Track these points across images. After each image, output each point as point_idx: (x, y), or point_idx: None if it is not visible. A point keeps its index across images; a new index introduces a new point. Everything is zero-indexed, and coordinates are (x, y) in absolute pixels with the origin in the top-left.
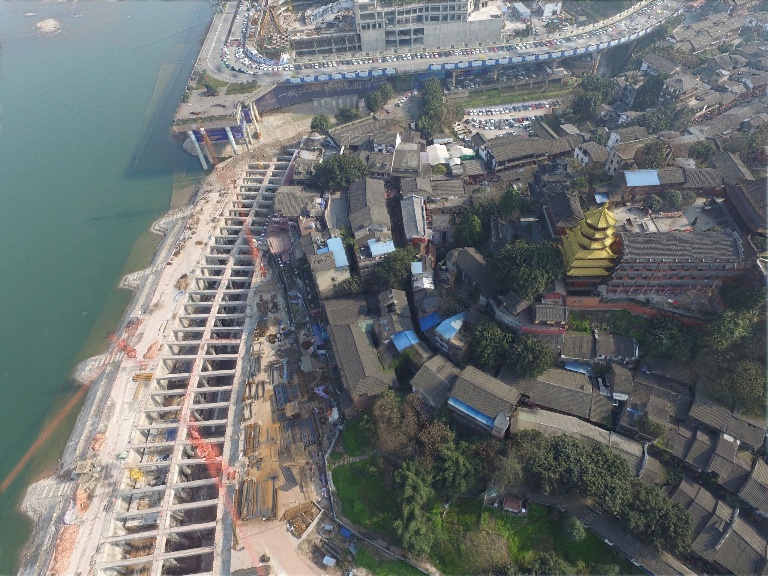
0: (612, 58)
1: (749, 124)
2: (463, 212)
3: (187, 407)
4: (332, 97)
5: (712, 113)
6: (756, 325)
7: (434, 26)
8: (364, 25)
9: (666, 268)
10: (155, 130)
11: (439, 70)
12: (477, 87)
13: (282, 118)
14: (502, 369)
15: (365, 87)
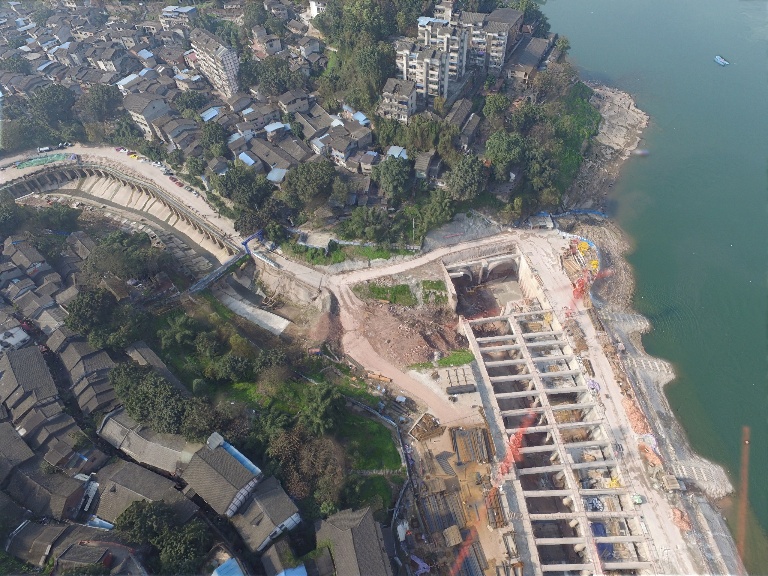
0: None
1: None
2: None
3: (596, 564)
4: None
5: None
6: None
7: None
8: None
9: None
10: None
11: None
12: None
13: None
14: (186, 520)
15: None
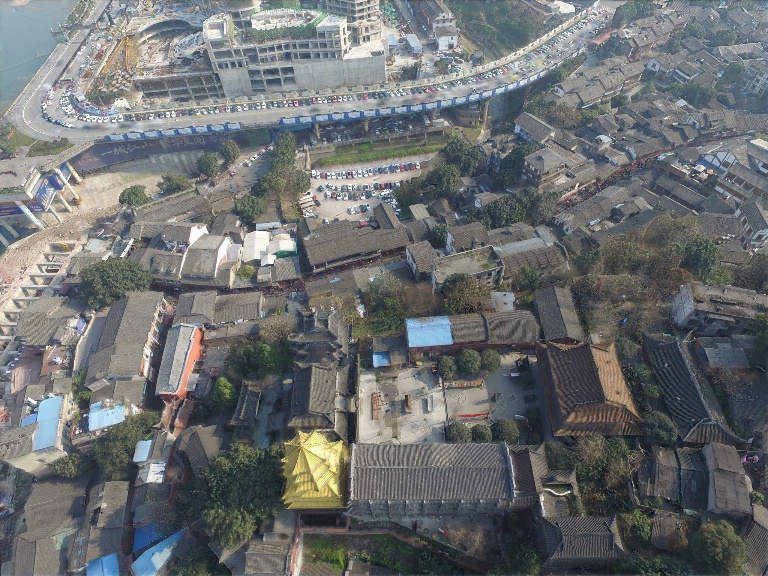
0: (509, 101)
1: (620, 212)
2: (253, 340)
3: None
4: (172, 153)
5: (588, 190)
6: None
7: (305, 65)
8: (221, 64)
9: (416, 506)
10: None
11: (294, 124)
12: (344, 141)
13: (110, 179)
14: None
15: (210, 142)
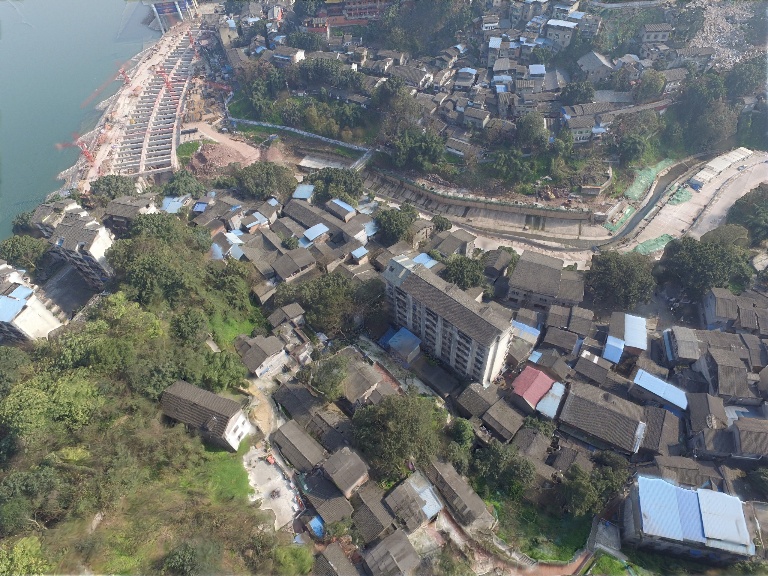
0: None
1: None
2: None
3: (158, 102)
4: None
5: None
6: (405, 17)
7: None
8: None
9: None
10: (129, 21)
11: None
12: None
13: (213, 6)
14: None
15: None
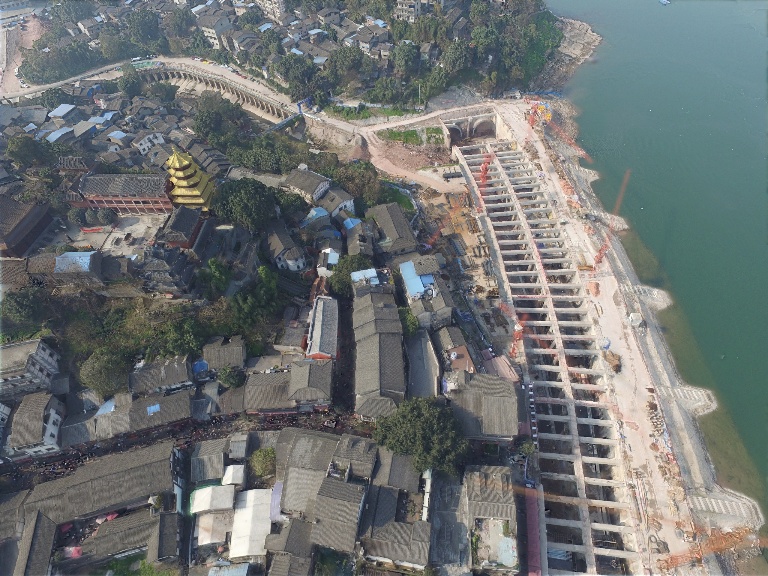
0: None
1: None
2: None
3: (534, 249)
4: None
5: None
6: None
7: None
8: None
9: None
10: None
11: None
12: None
13: None
14: None
15: None
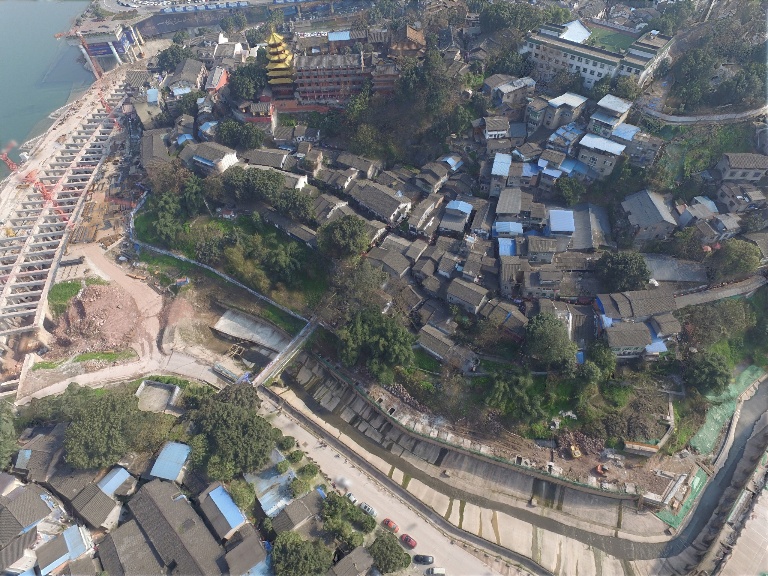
0: None
1: None
2: None
3: (51, 199)
4: (202, 26)
5: None
6: (378, 108)
7: None
8: None
9: (323, 74)
10: (64, 57)
11: (283, 3)
12: (317, 18)
13: (162, 43)
14: (236, 147)
15: None
